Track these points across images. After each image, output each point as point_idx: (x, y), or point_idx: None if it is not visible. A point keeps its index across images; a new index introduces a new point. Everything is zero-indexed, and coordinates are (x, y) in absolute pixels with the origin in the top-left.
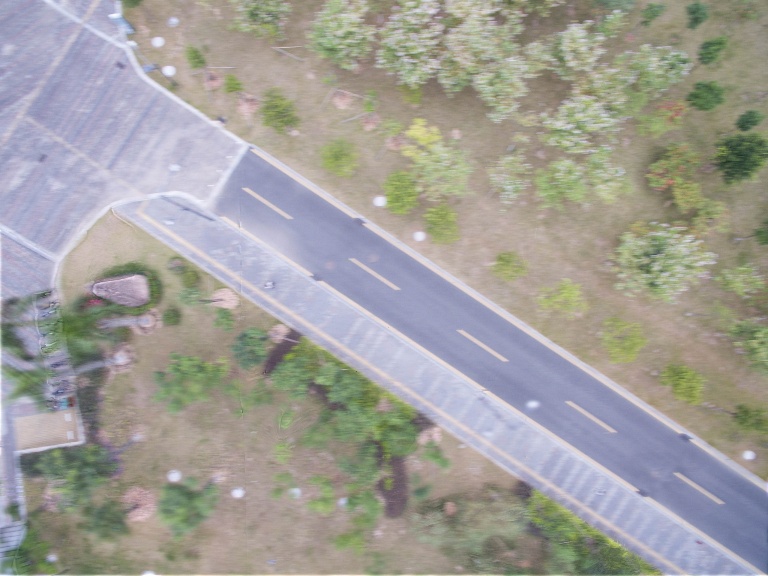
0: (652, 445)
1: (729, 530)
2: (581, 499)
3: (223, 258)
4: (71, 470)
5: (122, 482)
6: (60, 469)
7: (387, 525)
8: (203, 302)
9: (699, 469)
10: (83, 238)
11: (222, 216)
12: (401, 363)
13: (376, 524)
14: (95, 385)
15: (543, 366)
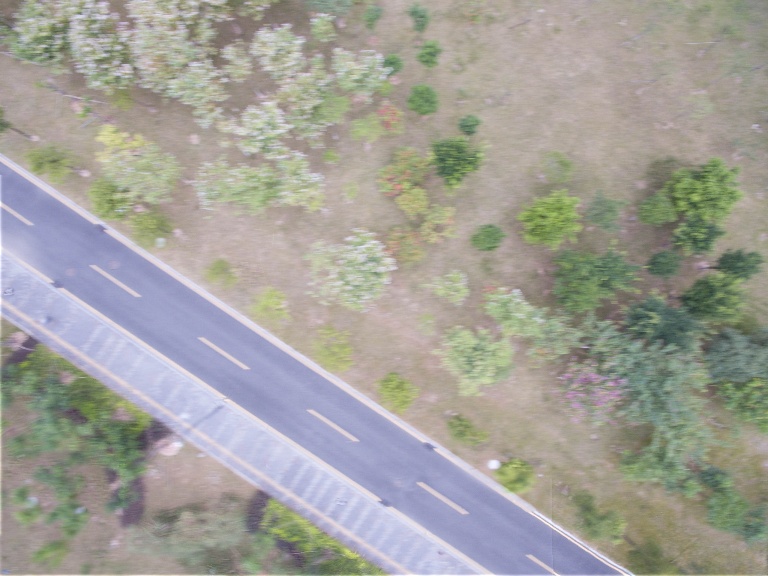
0: (395, 454)
1: (473, 540)
2: (322, 509)
3: None
4: None
5: None
6: None
7: (124, 535)
8: None
9: (443, 479)
10: None
11: None
12: (140, 371)
13: (113, 534)
14: None
15: (285, 374)
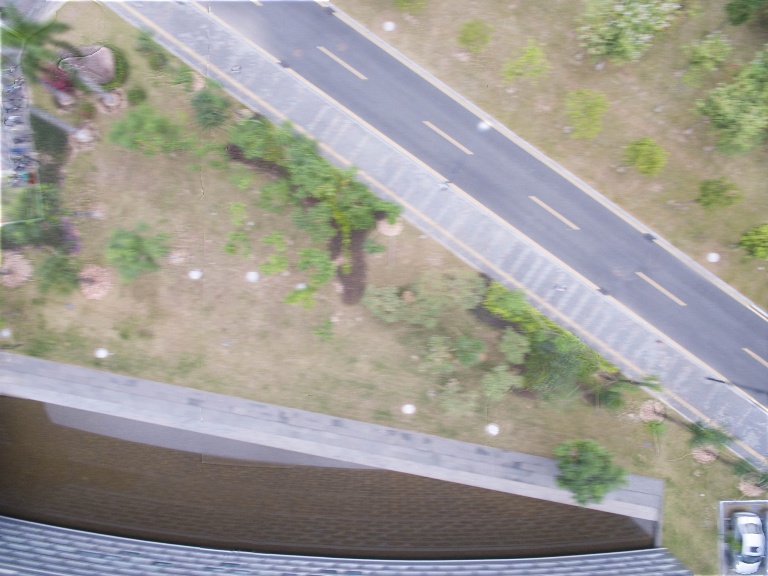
0: (615, 244)
1: (690, 332)
2: (541, 294)
3: (191, 42)
4: (29, 246)
5: (79, 260)
6: (18, 244)
7: (344, 312)
8: (169, 84)
9: (661, 269)
10: (52, 20)
11: (192, 0)
12: (365, 151)
13: (333, 310)
14: (57, 163)
15: (508, 160)
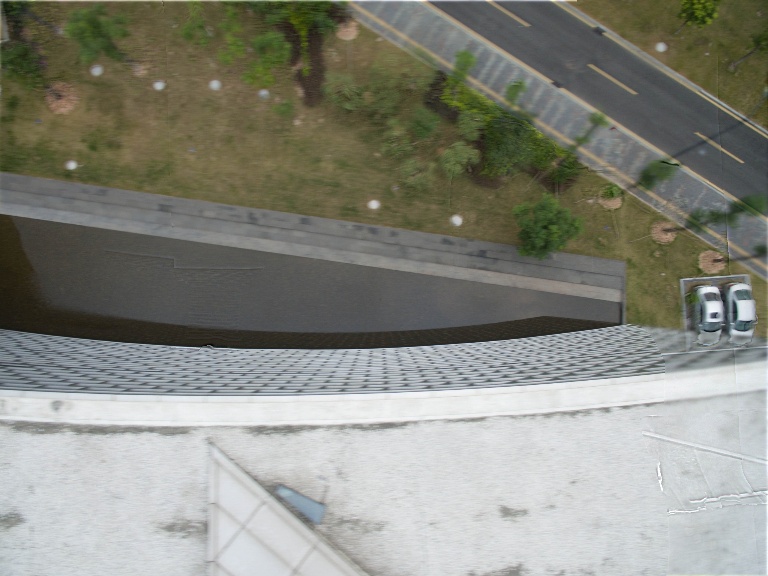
0: (566, 38)
1: (643, 119)
2: (497, 90)
3: None
4: None
5: (46, 77)
6: None
7: (307, 115)
8: None
9: (612, 61)
10: None
11: None
12: None
13: (296, 114)
14: None
15: None
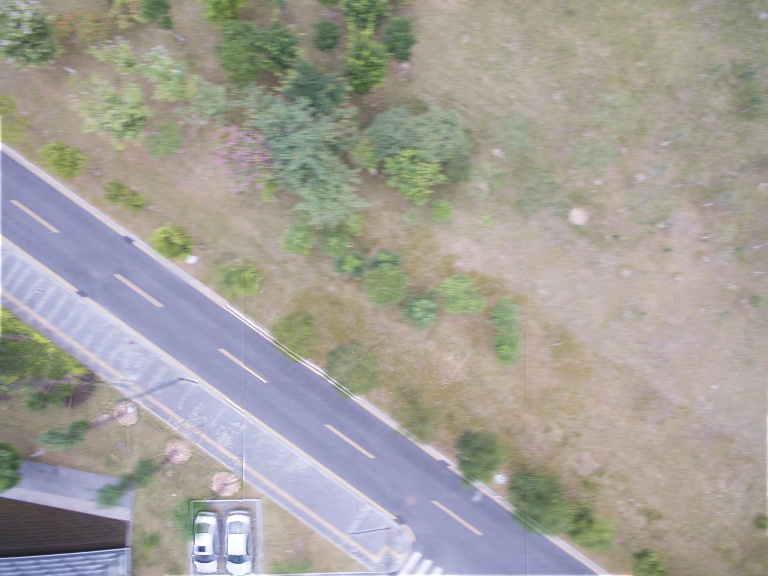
0: (94, 246)
1: (166, 333)
2: (19, 297)
3: None
4: None
5: None
6: None
7: None
8: None
9: (139, 271)
10: None
11: None
12: None
13: None
14: None
15: None
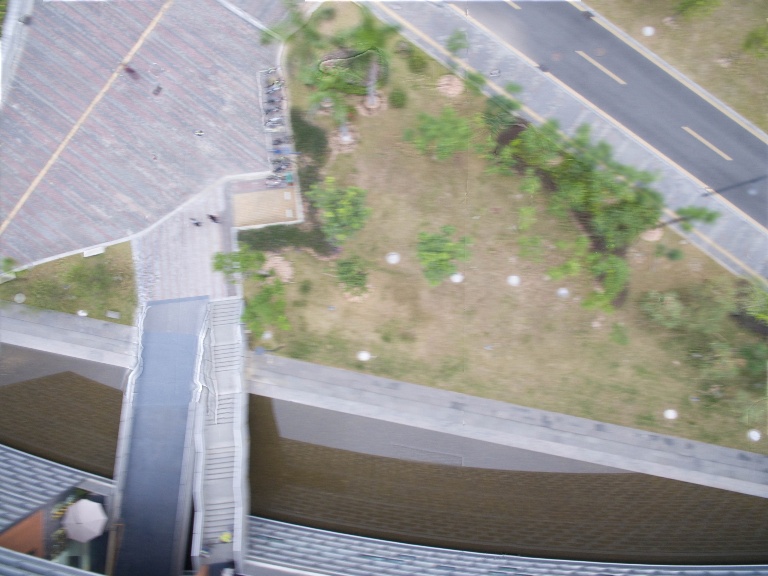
0: None
1: None
2: None
3: (449, 45)
4: (289, 248)
5: (340, 262)
6: (278, 246)
7: (606, 317)
8: (428, 87)
9: None
10: (306, 21)
11: (449, 3)
12: (625, 156)
13: (595, 315)
14: (316, 165)
15: (767, 166)
